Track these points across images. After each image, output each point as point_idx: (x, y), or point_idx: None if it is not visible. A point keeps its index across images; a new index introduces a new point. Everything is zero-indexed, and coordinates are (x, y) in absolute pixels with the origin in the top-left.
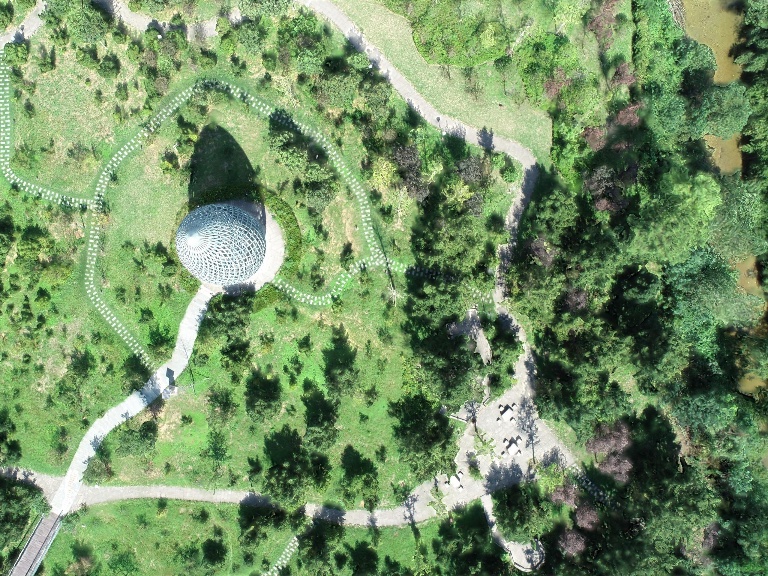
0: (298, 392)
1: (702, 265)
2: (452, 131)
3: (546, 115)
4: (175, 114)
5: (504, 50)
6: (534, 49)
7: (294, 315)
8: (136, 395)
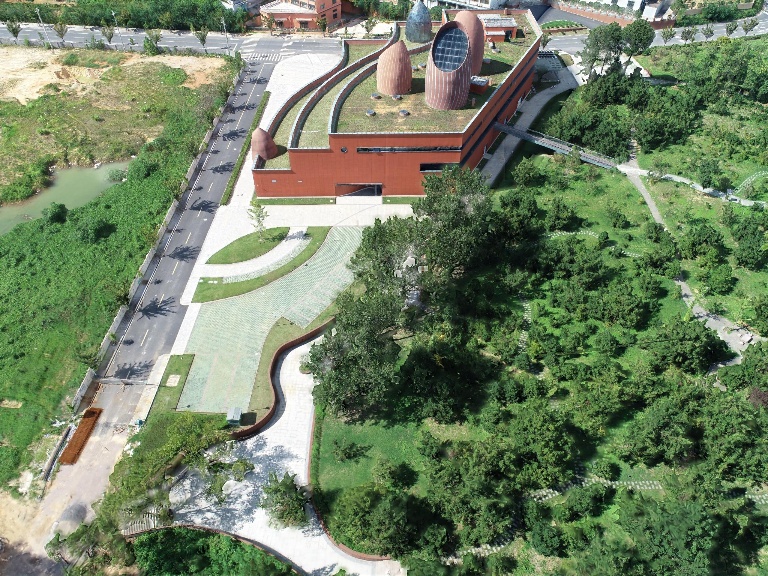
0: None
1: None
2: None
3: None
4: None
5: None
6: None
7: None
8: (710, 189)
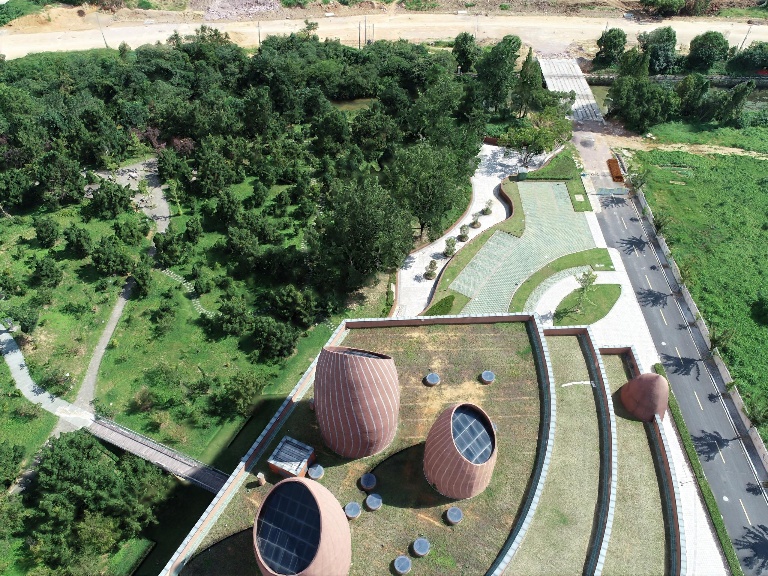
0: None
1: (60, 116)
2: None
3: None
4: None
5: None
6: None
7: None
8: (7, 357)
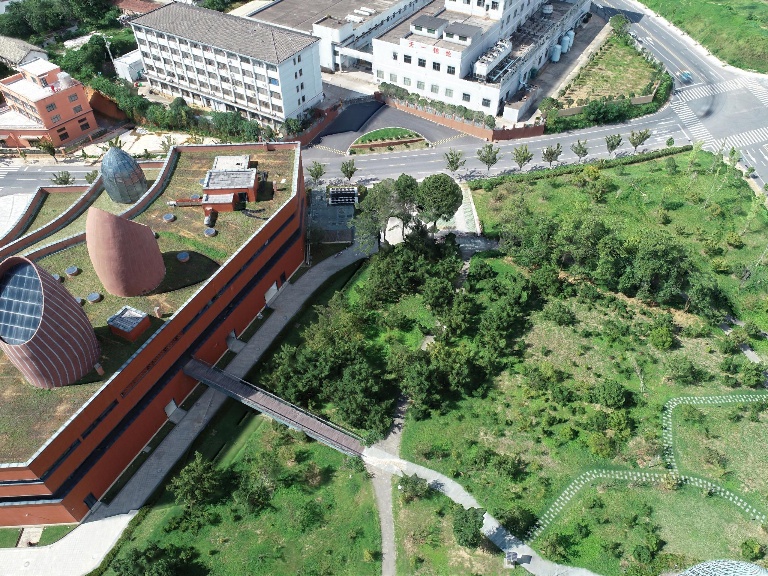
0: None
1: None
2: None
3: None
4: None
5: None
6: None
7: None
8: (494, 523)
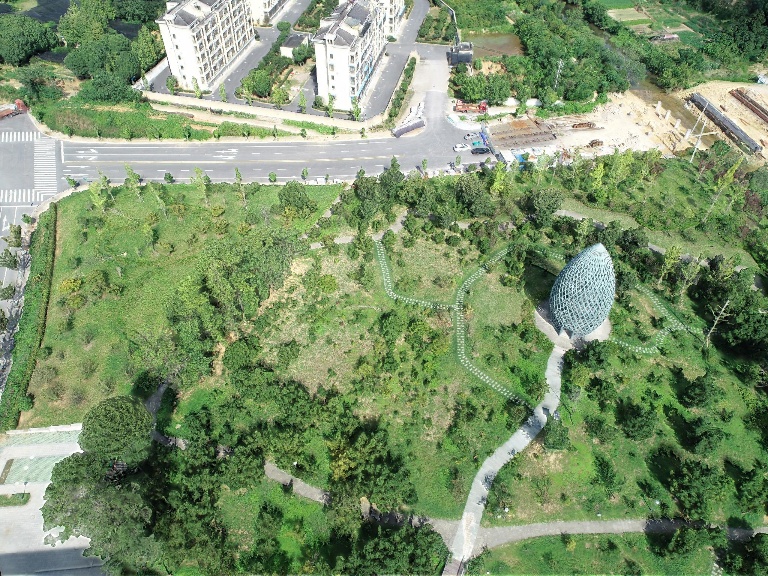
0: (661, 418)
1: None
2: (688, 260)
3: (743, 251)
4: (503, 258)
5: (698, 222)
6: (717, 220)
7: (635, 360)
8: (519, 433)
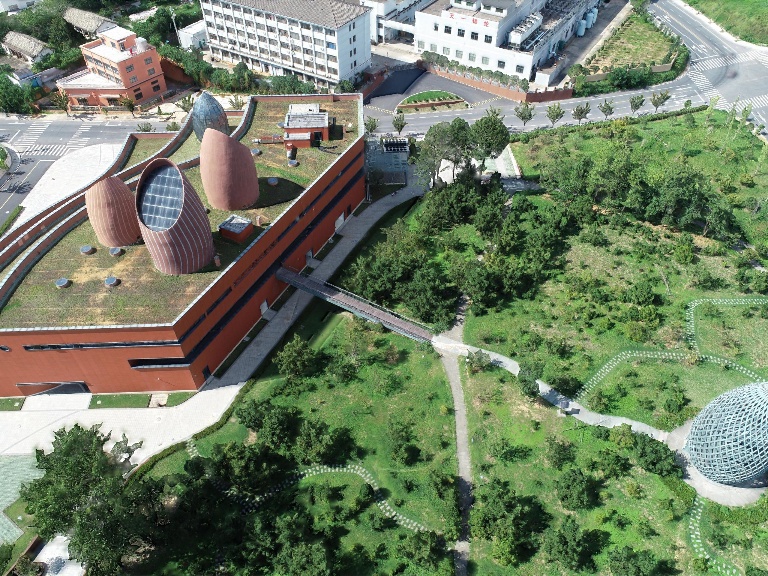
0: (592, 526)
1: None
2: None
3: None
4: None
5: None
6: None
7: (673, 518)
8: (547, 387)
